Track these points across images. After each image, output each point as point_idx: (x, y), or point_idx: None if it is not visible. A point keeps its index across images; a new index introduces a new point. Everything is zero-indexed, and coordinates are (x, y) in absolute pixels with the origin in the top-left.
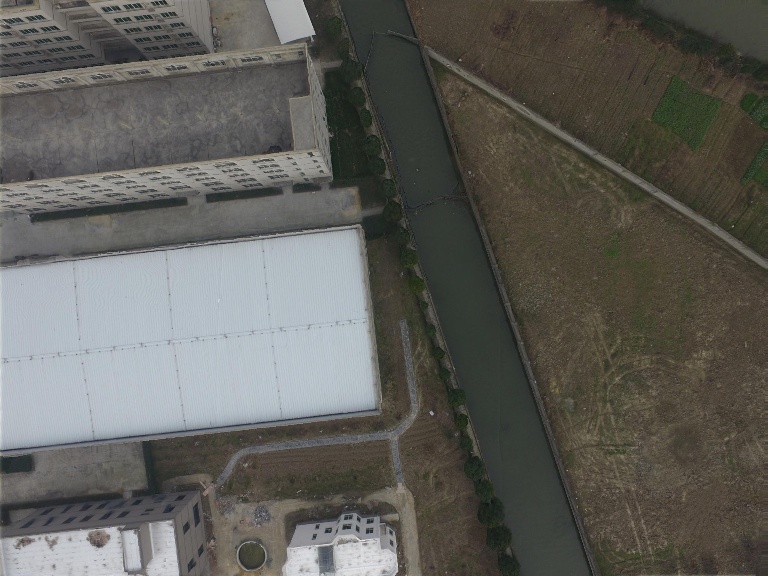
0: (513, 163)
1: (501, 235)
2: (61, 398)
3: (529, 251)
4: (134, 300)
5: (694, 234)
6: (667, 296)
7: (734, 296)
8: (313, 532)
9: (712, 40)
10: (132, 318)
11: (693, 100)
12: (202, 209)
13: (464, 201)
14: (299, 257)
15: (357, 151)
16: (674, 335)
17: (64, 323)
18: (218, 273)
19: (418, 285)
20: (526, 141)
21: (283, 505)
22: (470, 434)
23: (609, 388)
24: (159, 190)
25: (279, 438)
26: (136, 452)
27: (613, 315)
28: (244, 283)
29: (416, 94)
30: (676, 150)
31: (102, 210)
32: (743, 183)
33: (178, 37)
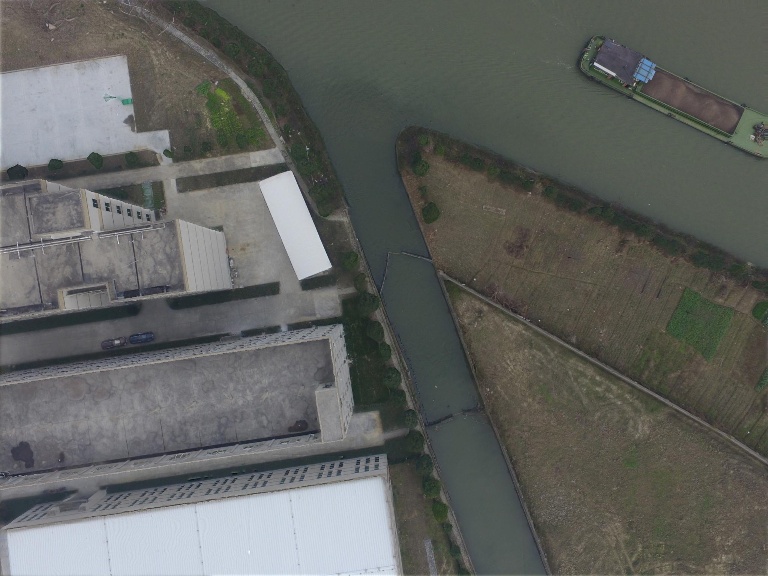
0: (530, 379)
1: (521, 450)
2: None
3: (549, 465)
4: (165, 553)
5: (710, 442)
6: (686, 503)
7: (751, 501)
8: None
9: (723, 253)
10: (164, 572)
11: (706, 311)
12: None
13: (483, 416)
14: (326, 505)
15: (377, 376)
16: (694, 541)
17: None
18: (247, 524)
19: (443, 517)
20: (542, 356)
21: None
22: None
23: None
24: None
25: None
26: None
27: (633, 524)
28: (273, 533)
29: (432, 308)
30: (690, 361)
31: None
32: (757, 391)
33: (198, 292)
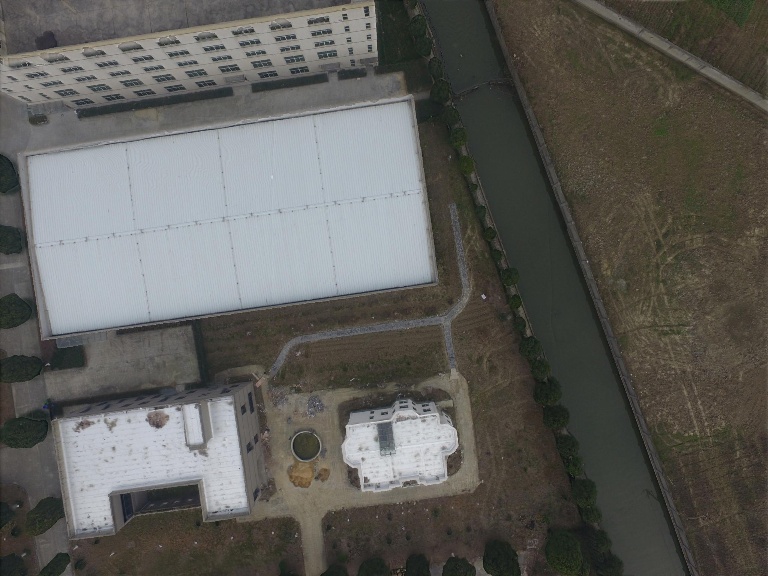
0: (558, 44)
1: (548, 117)
2: (117, 279)
3: (577, 132)
4: (187, 179)
5: (743, 110)
6: (717, 174)
7: None
8: (369, 415)
9: None
10: (186, 197)
11: None
12: (248, 99)
13: (509, 85)
14: (351, 131)
15: (401, 35)
16: (726, 213)
17: (118, 204)
18: (270, 150)
19: (469, 162)
20: (570, 22)
21: (336, 394)
22: (523, 317)
23: (661, 268)
24: (208, 72)
25: (331, 326)
26: (188, 345)
27: (663, 194)
28: (297, 158)
29: None
30: (722, 26)
31: (148, 103)
32: None
33: None
